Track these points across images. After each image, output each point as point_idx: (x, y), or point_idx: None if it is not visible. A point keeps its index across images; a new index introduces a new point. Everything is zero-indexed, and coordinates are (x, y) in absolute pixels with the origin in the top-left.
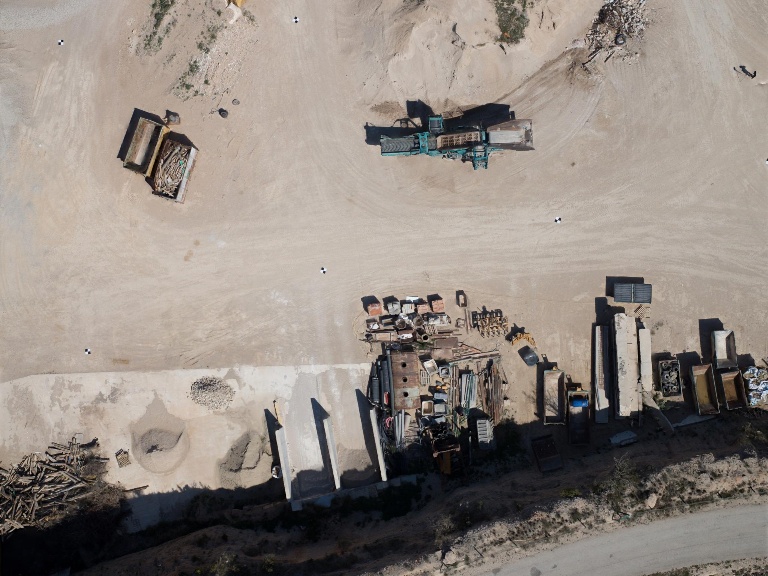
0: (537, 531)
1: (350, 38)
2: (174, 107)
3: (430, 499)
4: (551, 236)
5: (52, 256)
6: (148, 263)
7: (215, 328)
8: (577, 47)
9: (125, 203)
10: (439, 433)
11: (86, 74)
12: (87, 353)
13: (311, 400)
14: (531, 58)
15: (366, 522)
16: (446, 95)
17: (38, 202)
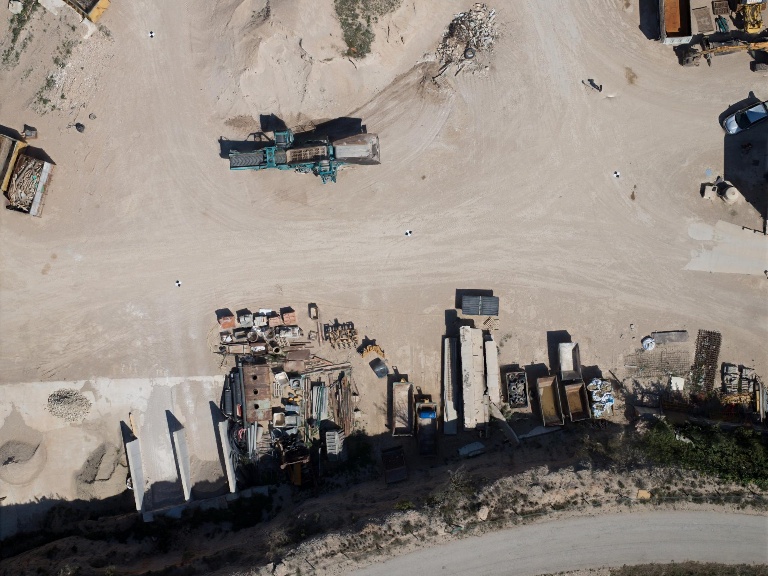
0: (368, 543)
1: (204, 53)
2: (32, 122)
3: (280, 510)
4: (402, 249)
5: None
6: (6, 276)
7: (72, 341)
8: (428, 61)
9: None
10: (289, 445)
11: None
12: None
13: (166, 412)
14: (382, 72)
15: (216, 533)
16: (299, 109)
17: None
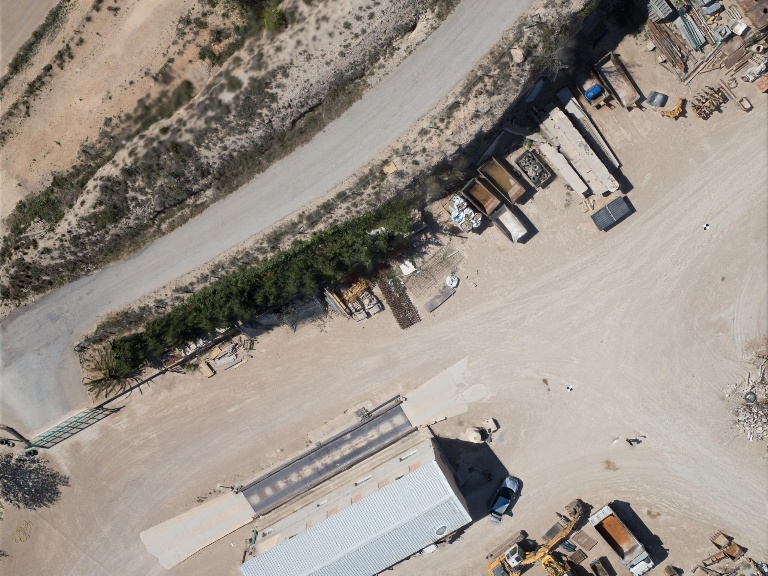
0: None
1: None
2: None
3: None
4: (704, 210)
5: None
6: None
7: None
8: None
9: None
10: None
11: None
12: None
13: None
14: None
15: None
16: None
17: None
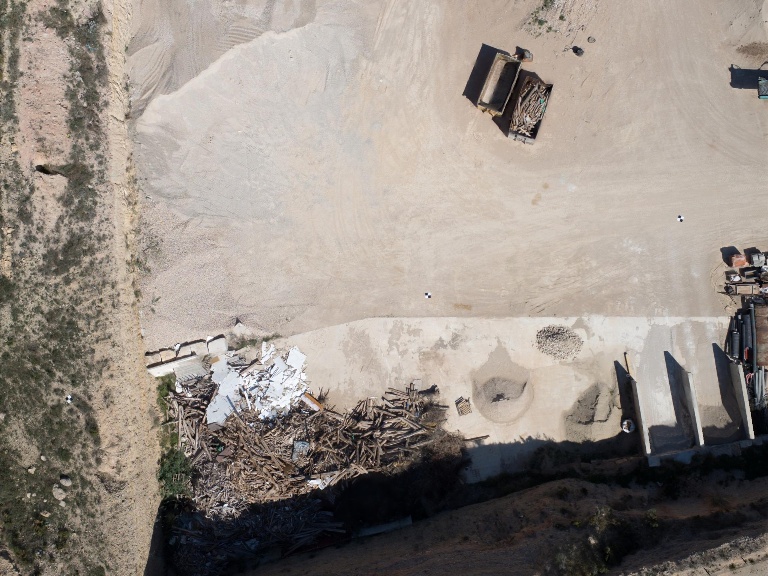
0: None
1: None
2: (525, 43)
3: None
4: None
5: (391, 196)
6: (493, 206)
7: (563, 275)
8: None
9: (470, 143)
10: None
11: (431, 7)
12: (427, 297)
13: (664, 353)
14: None
15: (729, 481)
16: None
17: (378, 139)
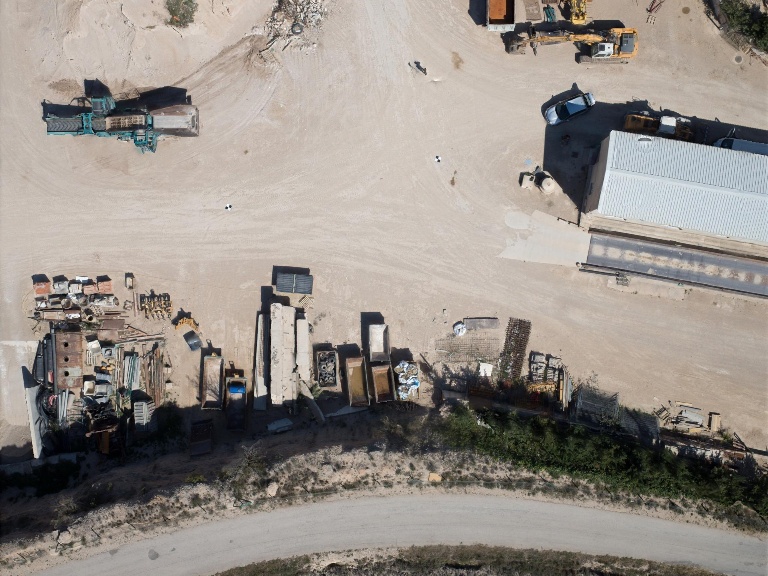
0: (154, 515)
1: (29, 12)
2: None
3: (87, 477)
4: (221, 223)
5: None
6: None
7: None
8: (256, 34)
9: None
10: (97, 413)
11: None
12: None
13: None
14: (208, 43)
15: (19, 498)
16: (124, 76)
17: None
